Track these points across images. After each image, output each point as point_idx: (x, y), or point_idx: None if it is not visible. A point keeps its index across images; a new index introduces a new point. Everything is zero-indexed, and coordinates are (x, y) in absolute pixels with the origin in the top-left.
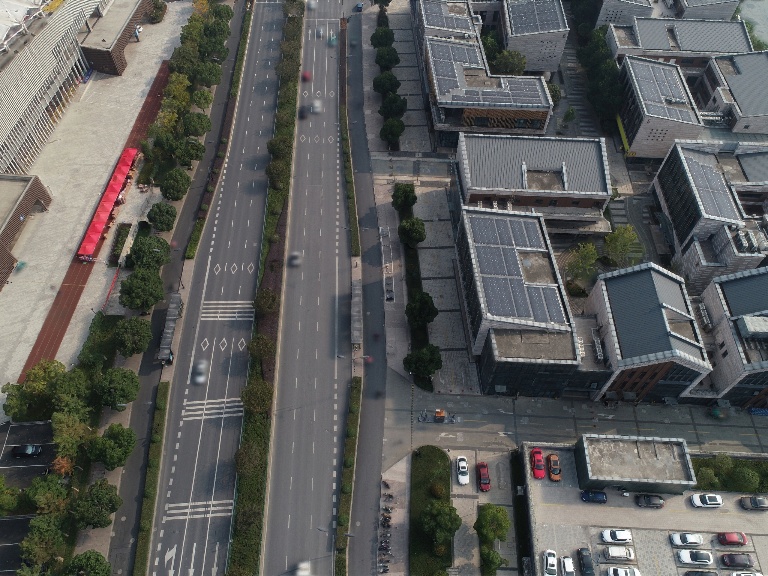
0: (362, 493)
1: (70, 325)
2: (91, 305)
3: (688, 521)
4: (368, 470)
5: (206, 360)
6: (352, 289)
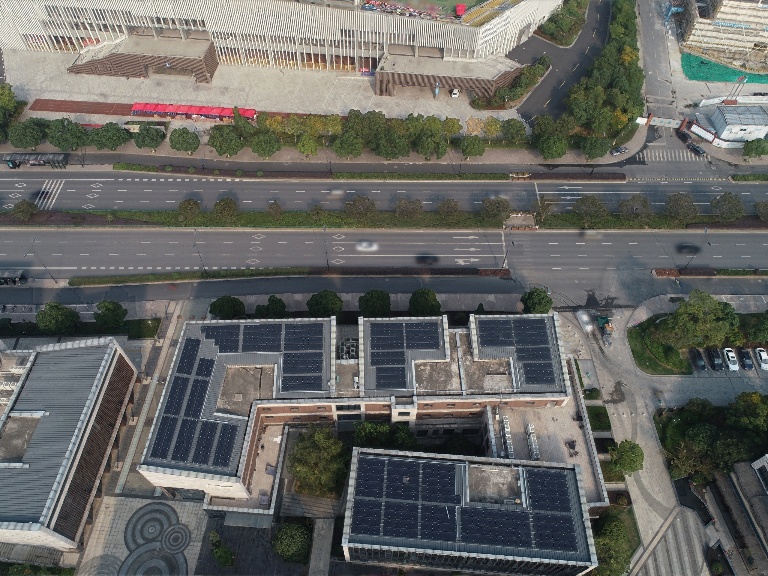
0: None
1: (75, 113)
2: (89, 120)
3: None
4: None
5: (5, 187)
6: (12, 270)
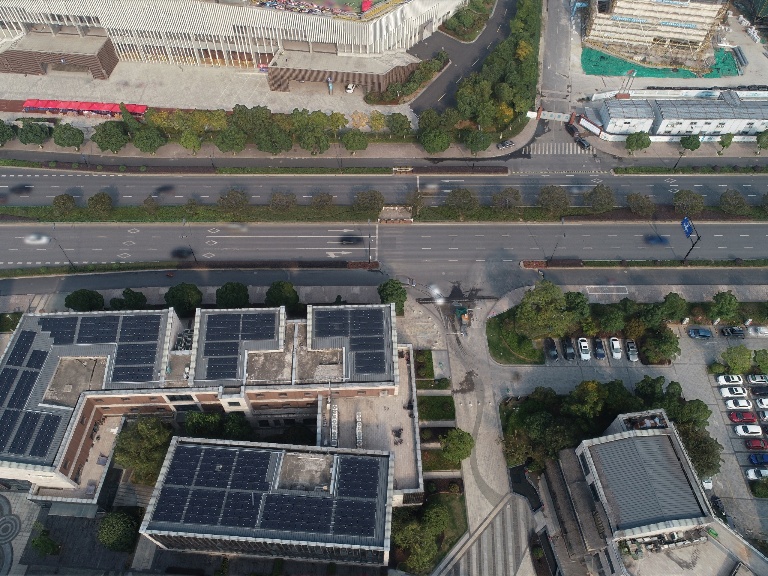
0: None
1: None
2: None
3: None
4: None
5: None
6: None
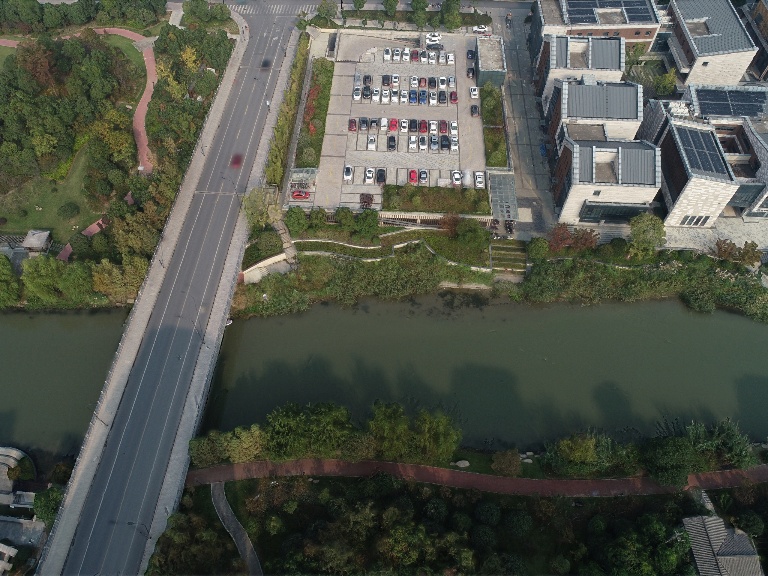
0: (464, 1)
1: None
2: None
3: (462, 86)
4: (476, 3)
5: None
6: None
